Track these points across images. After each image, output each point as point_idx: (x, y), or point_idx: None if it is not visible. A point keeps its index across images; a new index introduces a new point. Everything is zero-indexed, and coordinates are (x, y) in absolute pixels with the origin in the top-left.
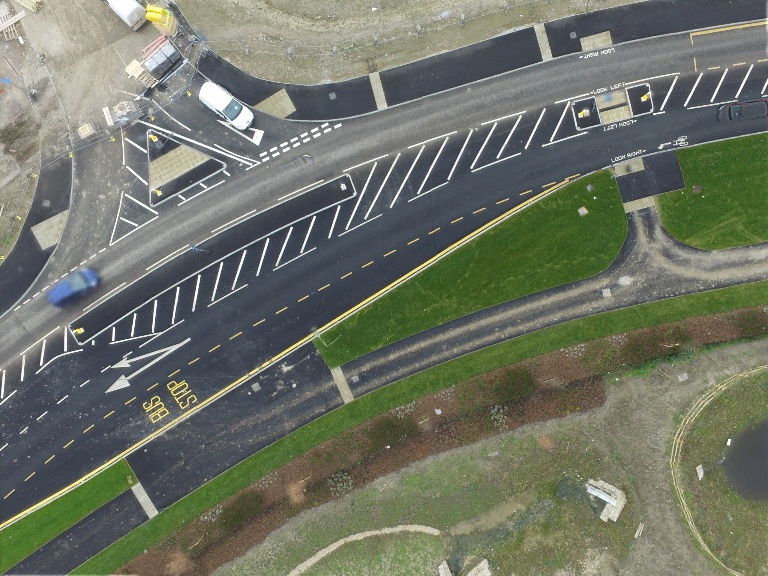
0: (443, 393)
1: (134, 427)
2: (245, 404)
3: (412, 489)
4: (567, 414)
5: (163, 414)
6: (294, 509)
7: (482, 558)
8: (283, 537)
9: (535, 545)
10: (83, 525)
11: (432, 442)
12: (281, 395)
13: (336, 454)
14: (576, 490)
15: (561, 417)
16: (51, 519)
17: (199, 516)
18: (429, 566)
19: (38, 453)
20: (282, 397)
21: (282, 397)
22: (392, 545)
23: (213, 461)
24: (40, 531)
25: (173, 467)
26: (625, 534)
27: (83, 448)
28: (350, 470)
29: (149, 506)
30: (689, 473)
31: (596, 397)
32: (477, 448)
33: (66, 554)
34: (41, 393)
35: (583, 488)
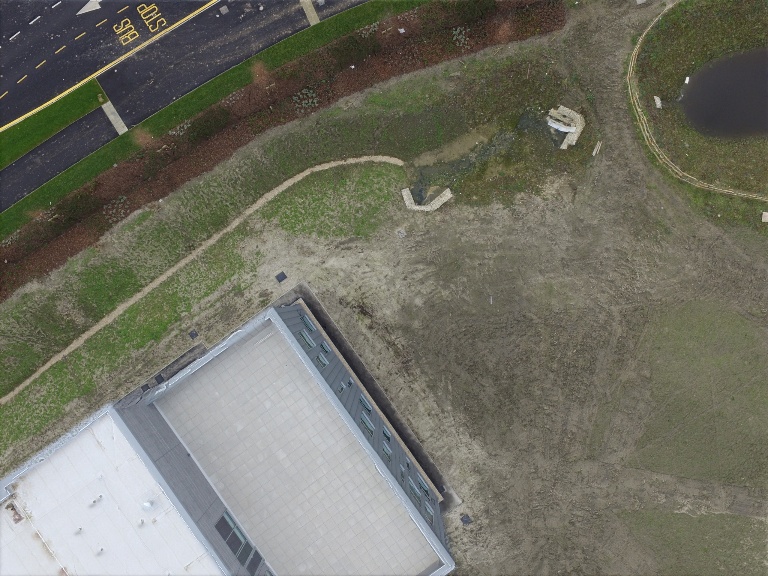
0: (406, 14)
1: (105, 49)
2: (213, 26)
3: (376, 108)
4: (528, 36)
5: (133, 37)
6: (260, 125)
7: (445, 188)
8: (249, 153)
9: (497, 176)
10: (54, 141)
11: (395, 62)
12: (248, 17)
13: (302, 72)
14: (537, 123)
15: (522, 40)
16: (23, 135)
17: (167, 131)
18: (392, 187)
19: (11, 73)
20: (249, 19)
21: (249, 19)
22: (357, 172)
23: (182, 80)
24: (12, 146)
25: (142, 86)
26: (583, 153)
27: (55, 69)
28: (315, 88)
29: (119, 123)
30: (646, 97)
31: (556, 20)
32: (439, 70)
33: (38, 169)
34: (14, 13)
35: (544, 121)
